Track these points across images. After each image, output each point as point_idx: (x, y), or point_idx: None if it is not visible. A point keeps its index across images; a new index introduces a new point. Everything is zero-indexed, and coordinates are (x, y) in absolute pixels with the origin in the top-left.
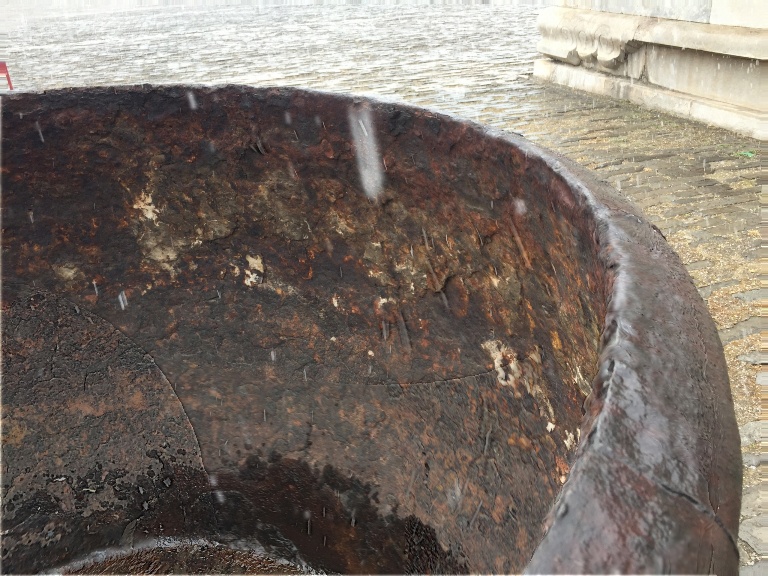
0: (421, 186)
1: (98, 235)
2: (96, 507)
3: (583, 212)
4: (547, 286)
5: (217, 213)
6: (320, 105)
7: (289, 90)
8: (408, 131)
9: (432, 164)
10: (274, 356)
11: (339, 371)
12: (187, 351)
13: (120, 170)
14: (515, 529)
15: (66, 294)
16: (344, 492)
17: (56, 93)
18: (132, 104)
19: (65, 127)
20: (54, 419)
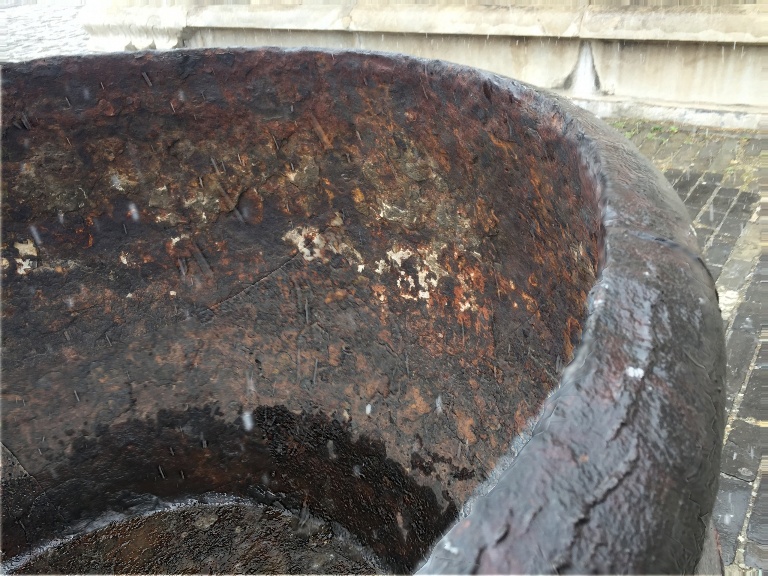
0: (212, 118)
1: None
2: None
3: (409, 65)
4: (348, 155)
5: None
6: (97, 67)
7: (58, 59)
8: (198, 71)
9: (225, 94)
10: (69, 336)
11: (144, 323)
12: None
13: None
14: (353, 360)
15: None
16: (186, 424)
17: None
18: None
19: None
20: None
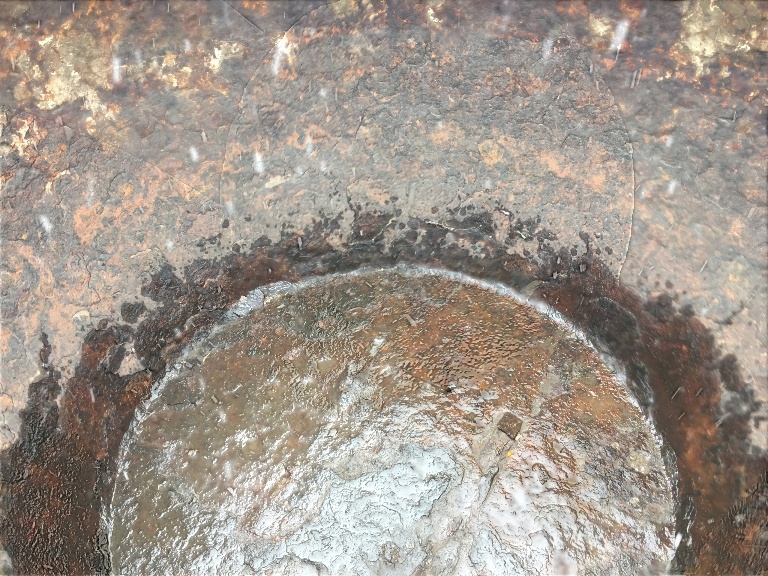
0: None
1: None
2: (519, 251)
3: None
4: None
5: None
6: None
7: None
8: None
9: None
10: (752, 214)
11: None
12: (668, 160)
13: None
14: None
15: (589, 49)
16: (730, 391)
17: None
18: None
19: None
20: (525, 160)
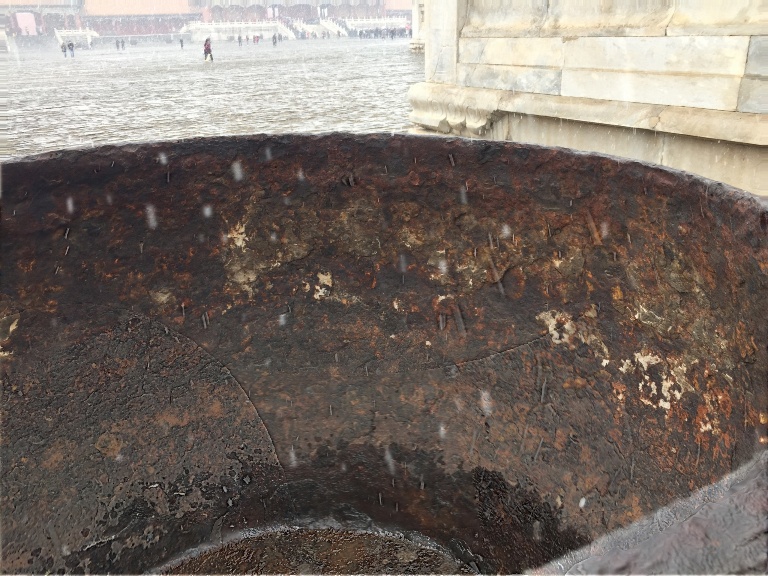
0: (498, 199)
1: (192, 262)
2: (187, 508)
3: (691, 183)
4: (615, 254)
5: (298, 238)
6: (415, 145)
7: (387, 135)
8: (495, 159)
9: (514, 181)
10: (338, 358)
11: (398, 363)
12: (259, 361)
13: (224, 205)
14: (578, 449)
15: (158, 317)
16: (411, 463)
17: (188, 141)
18: (248, 150)
19: (189, 169)
20: (145, 431)
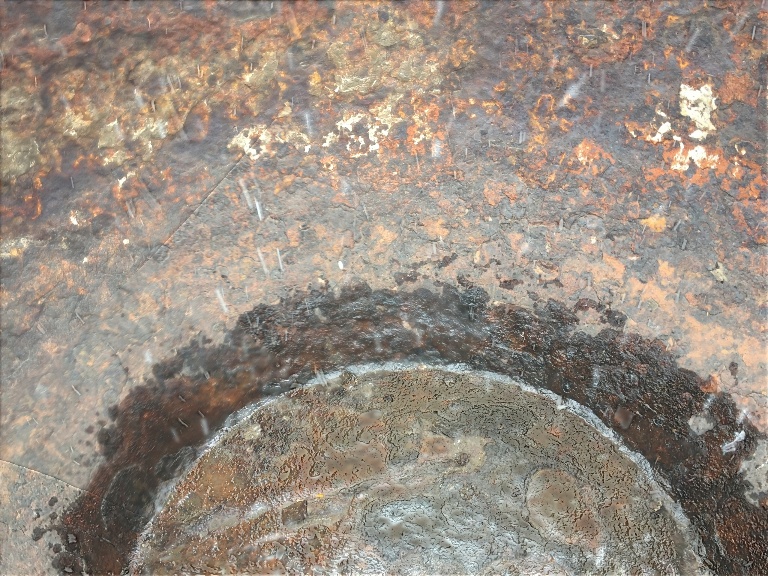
0: (184, 29)
1: None
2: None
3: None
4: (314, 41)
5: None
6: None
7: None
8: None
9: (204, 1)
10: (42, 328)
11: (106, 285)
12: None
13: None
14: (312, 233)
15: None
16: (183, 367)
17: None
18: None
19: None
20: None
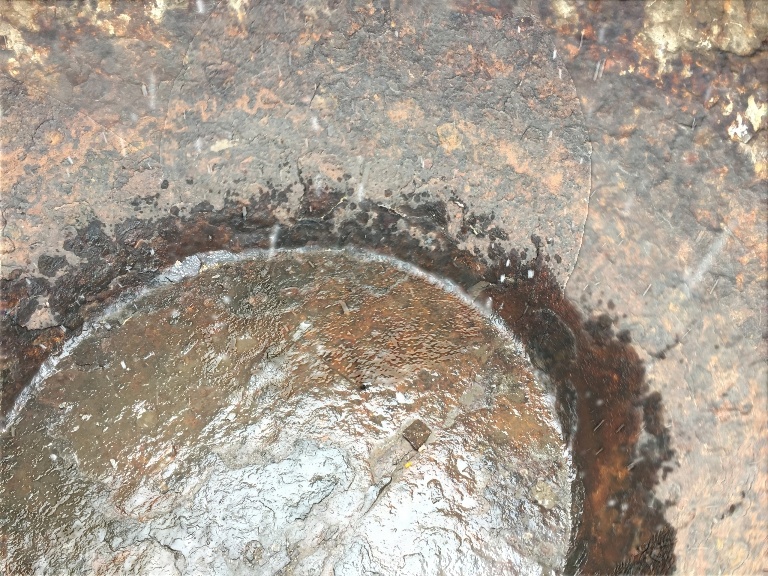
0: None
1: None
2: (470, 247)
3: None
4: None
5: (747, 16)
6: None
7: None
8: None
9: None
10: (701, 238)
11: (749, 315)
12: (626, 166)
13: None
14: None
15: (553, 31)
16: (649, 433)
17: None
18: None
19: None
20: (484, 149)
